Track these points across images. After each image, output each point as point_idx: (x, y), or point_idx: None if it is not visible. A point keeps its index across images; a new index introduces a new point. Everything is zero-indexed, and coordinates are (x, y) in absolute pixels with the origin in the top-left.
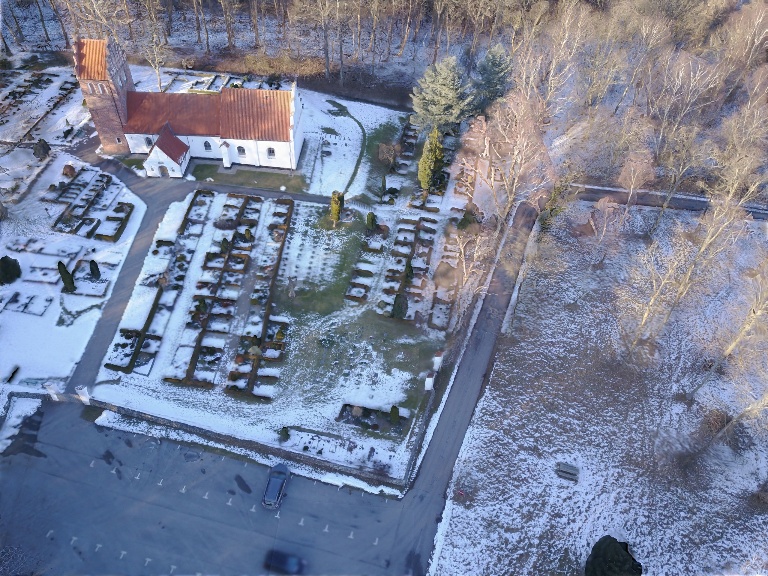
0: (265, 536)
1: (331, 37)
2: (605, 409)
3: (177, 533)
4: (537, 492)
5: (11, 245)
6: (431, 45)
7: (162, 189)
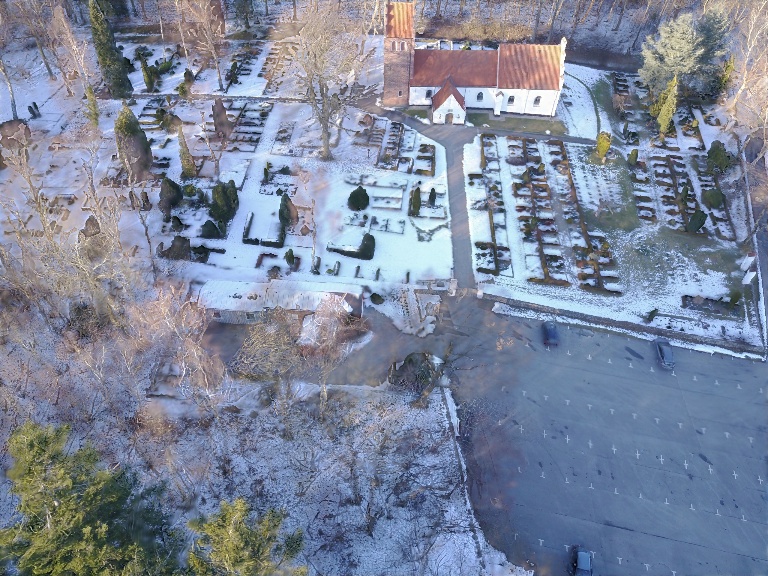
0: (672, 388)
1: (508, 8)
2: None
3: (602, 387)
4: None
5: (349, 180)
6: (617, 11)
7: (450, 134)
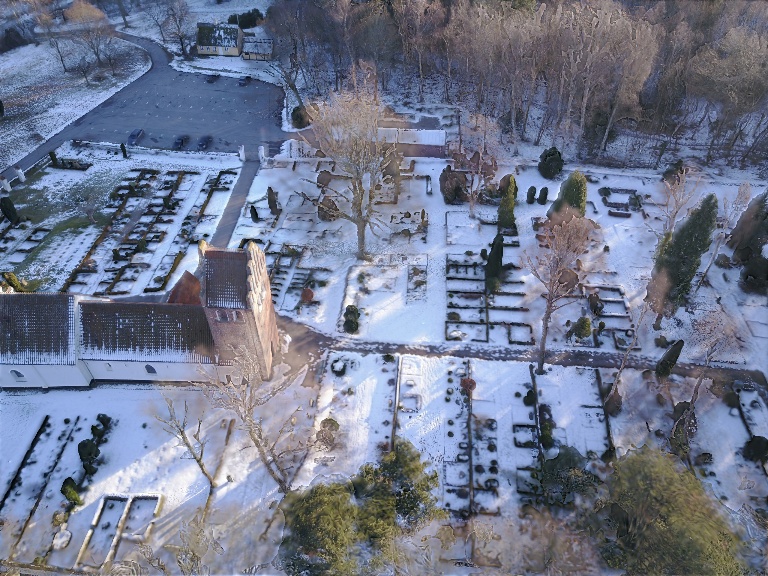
0: None
1: None
2: None
3: None
4: None
5: None
6: None
7: None
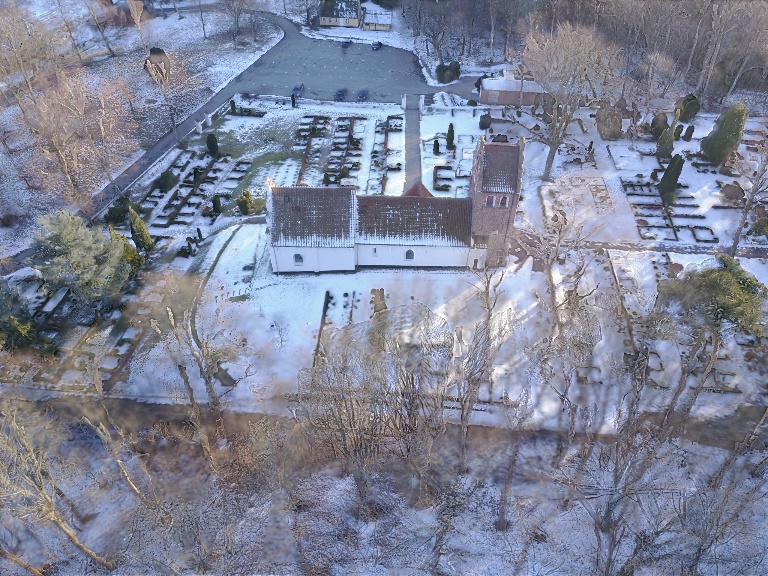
0: None
1: None
2: None
3: None
4: (172, 94)
5: None
6: None
7: None
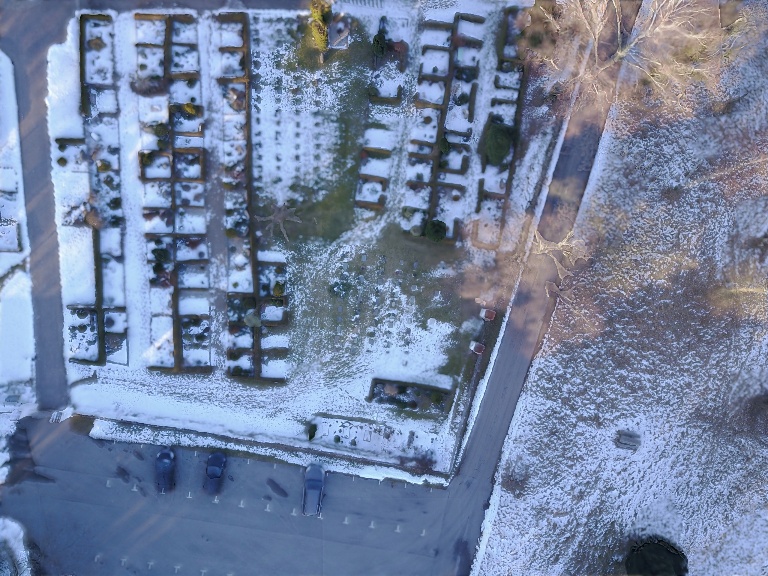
0: (311, 538)
1: None
2: (685, 355)
3: (223, 544)
4: (591, 470)
5: None
6: None
7: (20, 16)
